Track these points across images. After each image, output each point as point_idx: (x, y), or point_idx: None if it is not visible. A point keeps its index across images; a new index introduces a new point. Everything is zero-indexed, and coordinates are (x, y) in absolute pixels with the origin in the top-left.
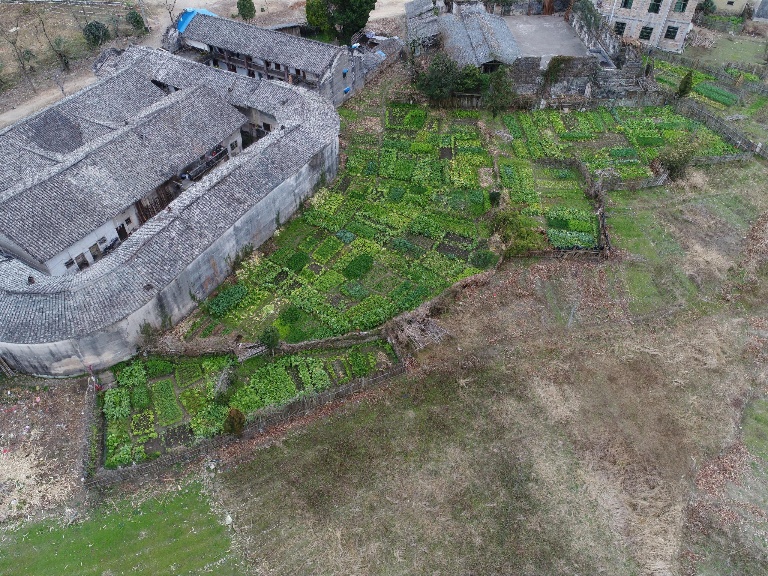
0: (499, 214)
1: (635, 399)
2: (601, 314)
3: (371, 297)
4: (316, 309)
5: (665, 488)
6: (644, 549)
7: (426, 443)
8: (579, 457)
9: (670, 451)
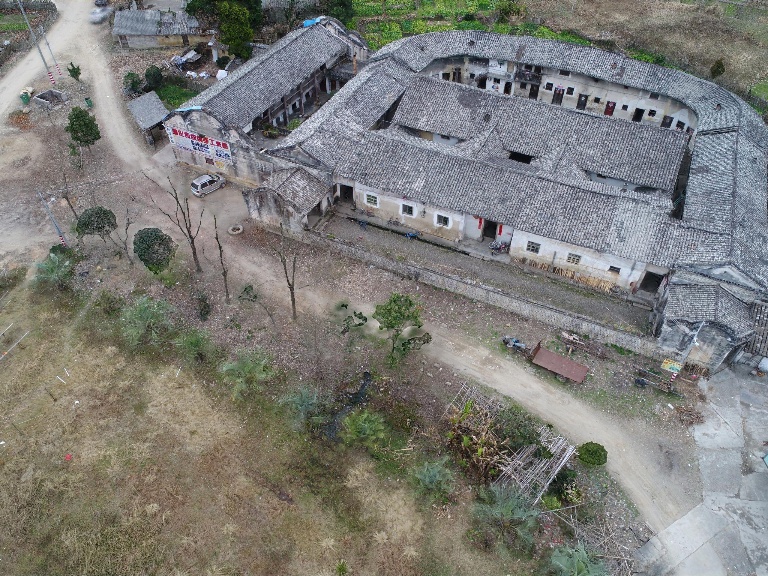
0: (504, 7)
1: (605, 4)
2: (555, 5)
3: None
4: None
5: (649, 3)
6: (680, 7)
7: None
8: (648, 15)
9: (628, 1)
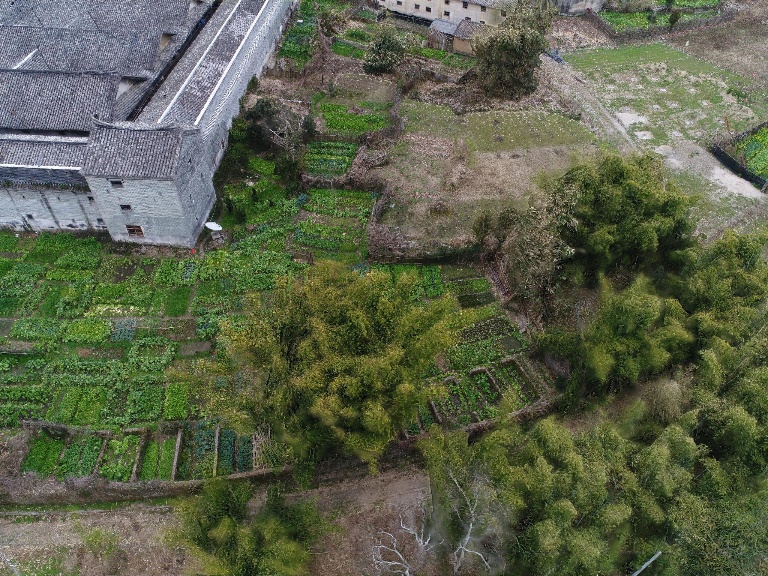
0: None
1: None
2: None
3: (699, 1)
4: (677, 1)
5: None
6: None
7: (755, 37)
8: None
9: None
